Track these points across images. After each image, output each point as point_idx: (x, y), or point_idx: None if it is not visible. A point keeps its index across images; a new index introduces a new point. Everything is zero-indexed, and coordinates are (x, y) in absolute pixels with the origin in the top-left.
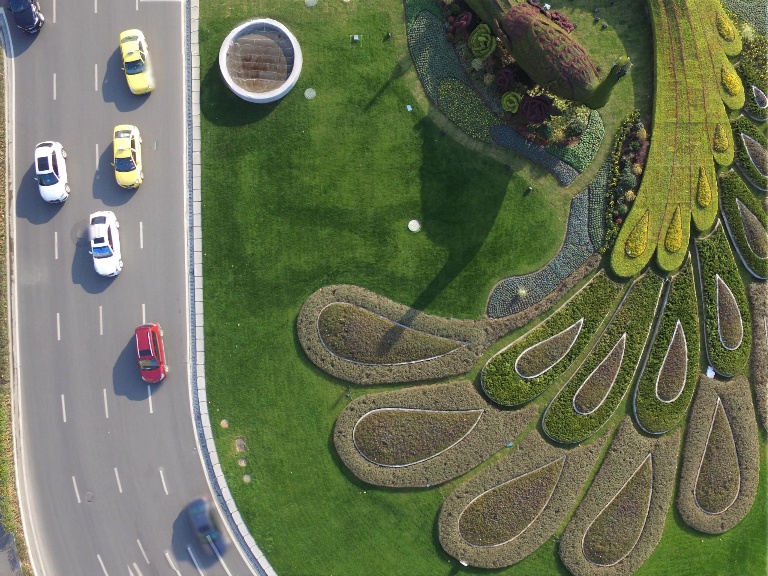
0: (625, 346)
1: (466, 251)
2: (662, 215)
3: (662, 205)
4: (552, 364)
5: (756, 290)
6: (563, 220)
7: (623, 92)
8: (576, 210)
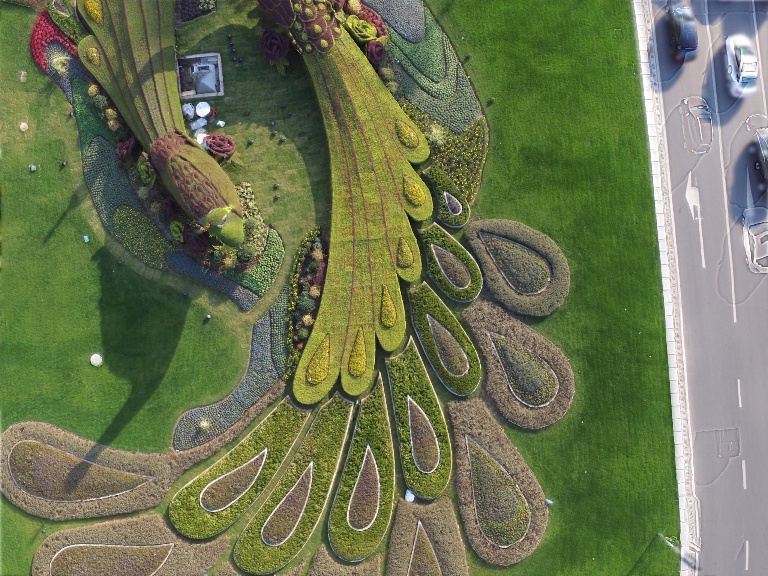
0: (312, 475)
1: (148, 384)
2: (343, 338)
3: (343, 328)
4: (237, 496)
5: (454, 408)
6: (245, 347)
7: (303, 209)
8: (258, 336)
